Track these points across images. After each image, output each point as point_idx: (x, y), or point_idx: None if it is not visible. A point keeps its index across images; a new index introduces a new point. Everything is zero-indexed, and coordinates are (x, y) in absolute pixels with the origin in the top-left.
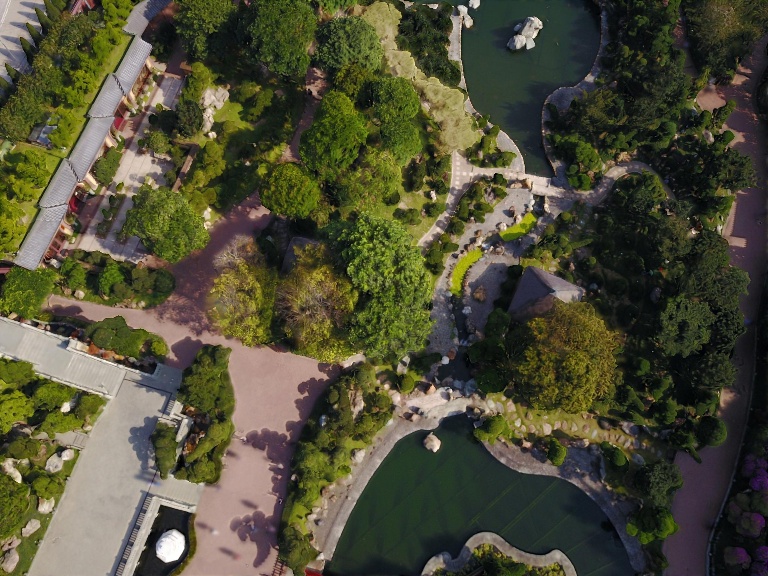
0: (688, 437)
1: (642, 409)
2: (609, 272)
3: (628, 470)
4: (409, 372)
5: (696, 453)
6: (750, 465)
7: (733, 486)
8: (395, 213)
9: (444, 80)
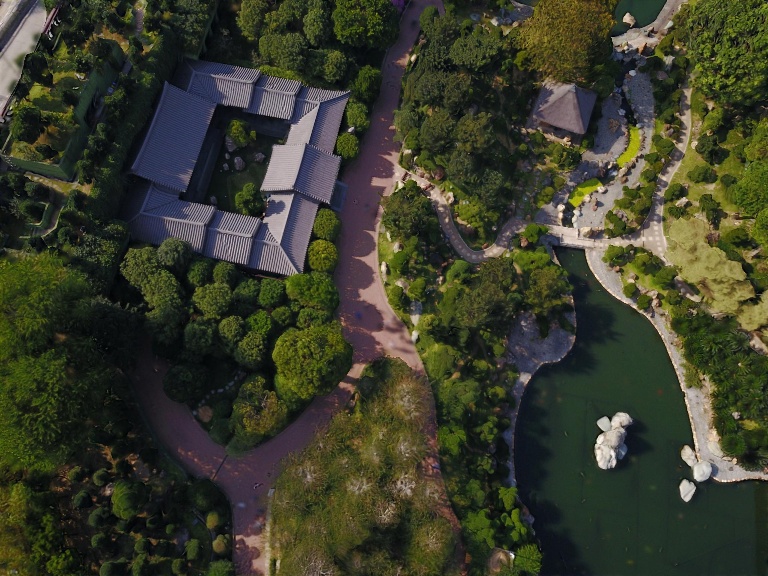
0: (454, 8)
1: (490, 22)
2: (505, 143)
3: (485, 8)
4: (662, 58)
5: (445, 4)
6: (403, 3)
7: (407, 4)
8: (716, 177)
9: (708, 335)
